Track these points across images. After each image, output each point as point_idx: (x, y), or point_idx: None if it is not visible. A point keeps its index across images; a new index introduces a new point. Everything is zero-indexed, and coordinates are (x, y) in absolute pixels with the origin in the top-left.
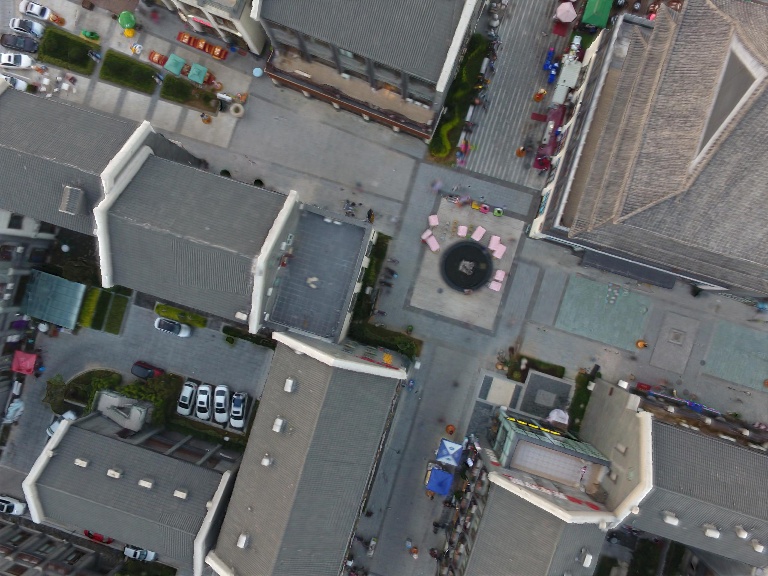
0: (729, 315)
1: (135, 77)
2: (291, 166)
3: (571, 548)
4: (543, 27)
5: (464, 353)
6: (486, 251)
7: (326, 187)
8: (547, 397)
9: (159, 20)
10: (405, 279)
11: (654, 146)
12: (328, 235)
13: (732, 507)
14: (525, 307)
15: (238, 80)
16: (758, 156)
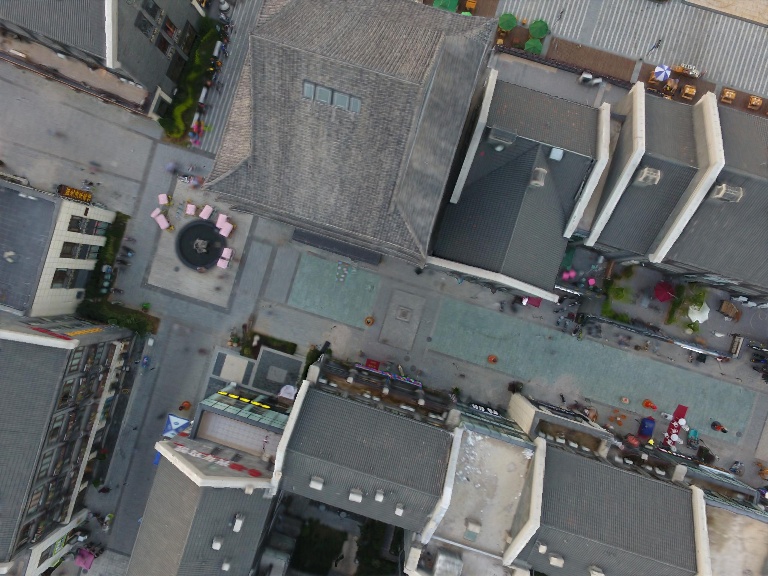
0: (454, 292)
1: None
2: (33, 146)
3: (219, 513)
4: None
5: (200, 330)
6: (218, 230)
7: (67, 167)
8: (278, 373)
9: None
10: (143, 258)
11: (239, 115)
12: (26, 210)
13: (368, 471)
14: (258, 285)
15: None
16: (289, 120)
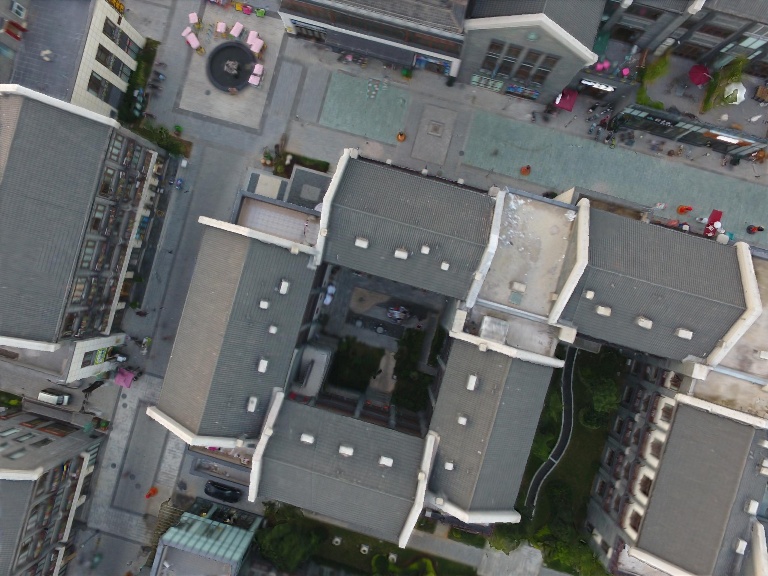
0: (485, 105)
1: None
2: None
3: (266, 274)
4: None
5: (232, 153)
6: (249, 50)
7: None
8: (312, 192)
9: None
10: (174, 82)
11: None
12: (61, 9)
13: (413, 223)
14: (290, 105)
15: None
16: None
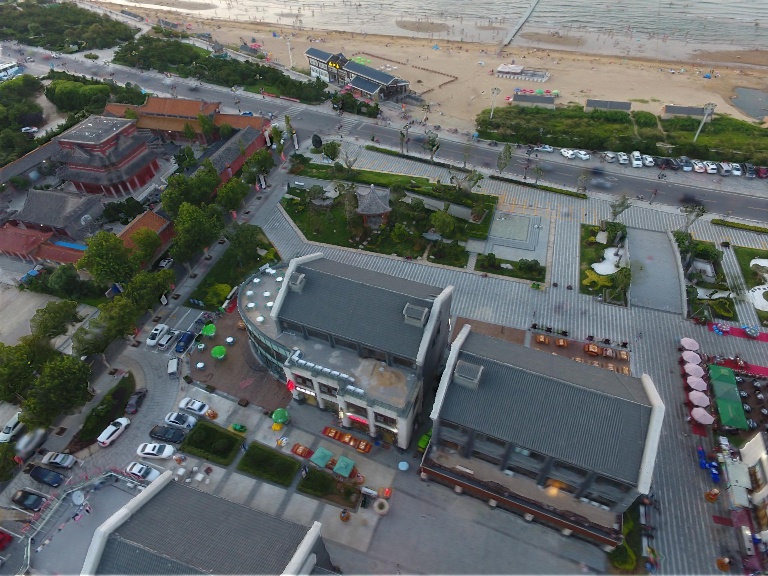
0: None
1: (277, 469)
2: None
3: None
4: (681, 428)
5: None
6: None
7: None
8: None
9: (307, 416)
10: None
11: None
12: None
13: None
14: None
15: (381, 473)
16: None
